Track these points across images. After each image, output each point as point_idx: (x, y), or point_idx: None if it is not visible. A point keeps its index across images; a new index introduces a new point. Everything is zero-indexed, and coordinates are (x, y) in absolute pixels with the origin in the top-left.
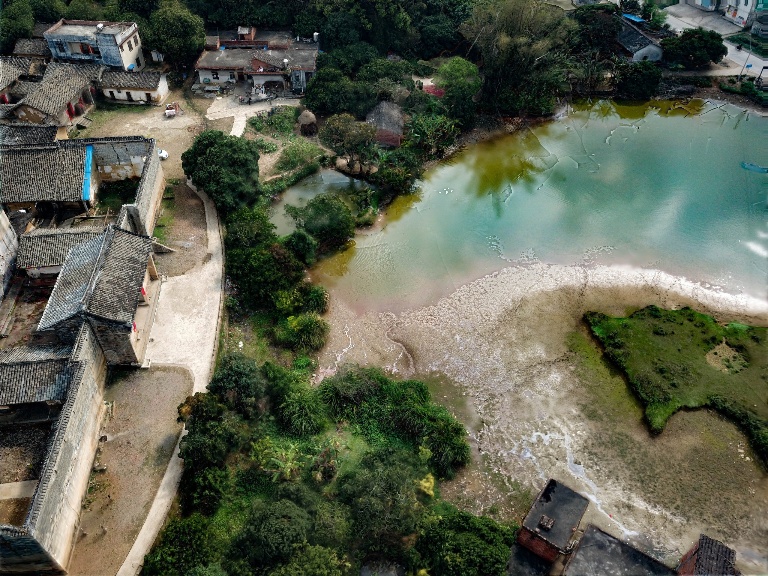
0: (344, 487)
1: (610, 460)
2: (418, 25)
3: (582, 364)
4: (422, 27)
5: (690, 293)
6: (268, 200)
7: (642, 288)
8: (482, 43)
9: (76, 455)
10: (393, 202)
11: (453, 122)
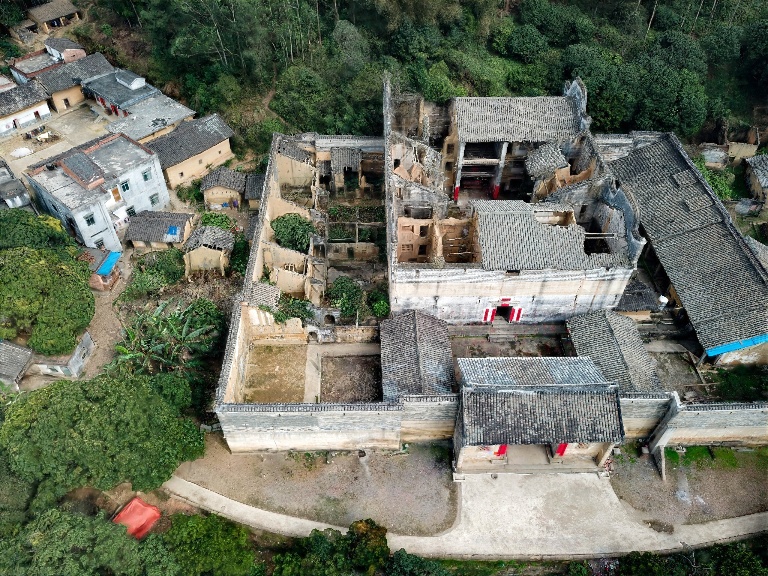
0: None
1: None
2: None
3: None
4: None
5: None
6: None
7: None
8: None
9: (316, 430)
10: None
11: None
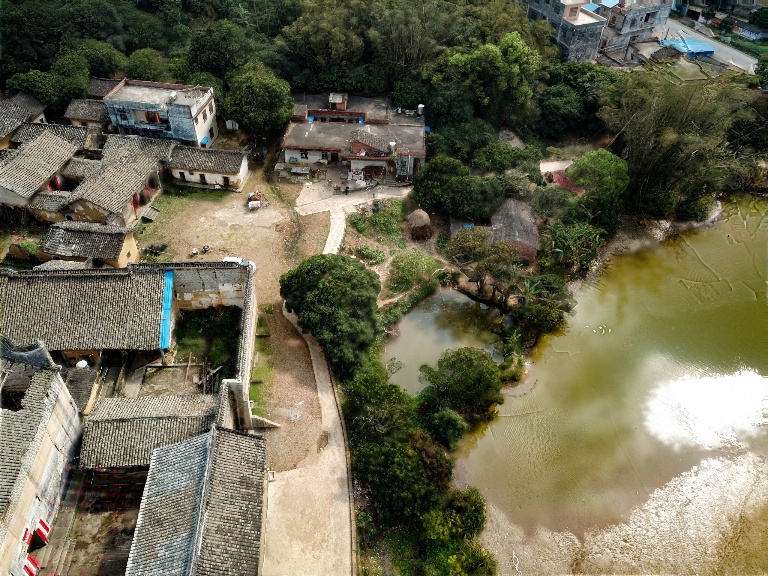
0: None
1: None
2: (536, 96)
3: None
4: (542, 100)
5: None
6: (383, 336)
7: None
8: (633, 134)
9: None
10: (538, 343)
11: (598, 231)
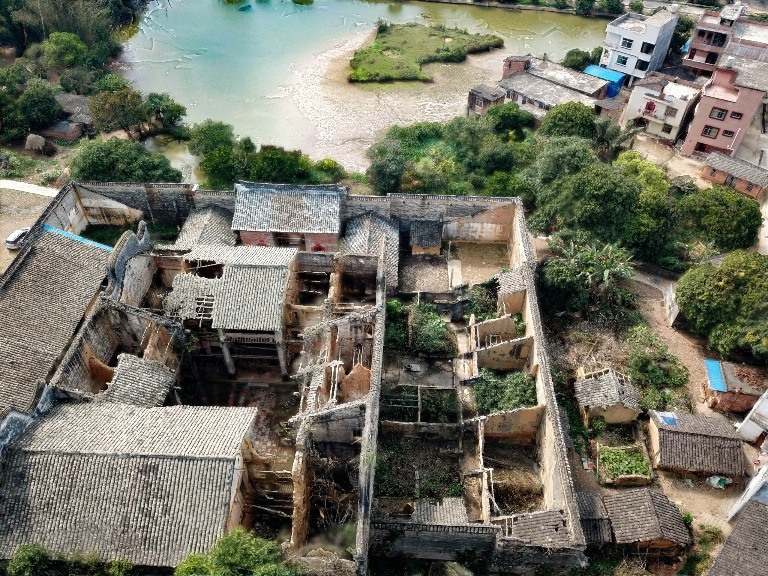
0: (464, 150)
1: (445, 95)
2: None
3: (383, 90)
4: None
5: (342, 52)
6: None
7: (332, 62)
8: (54, 15)
9: None
10: None
11: None
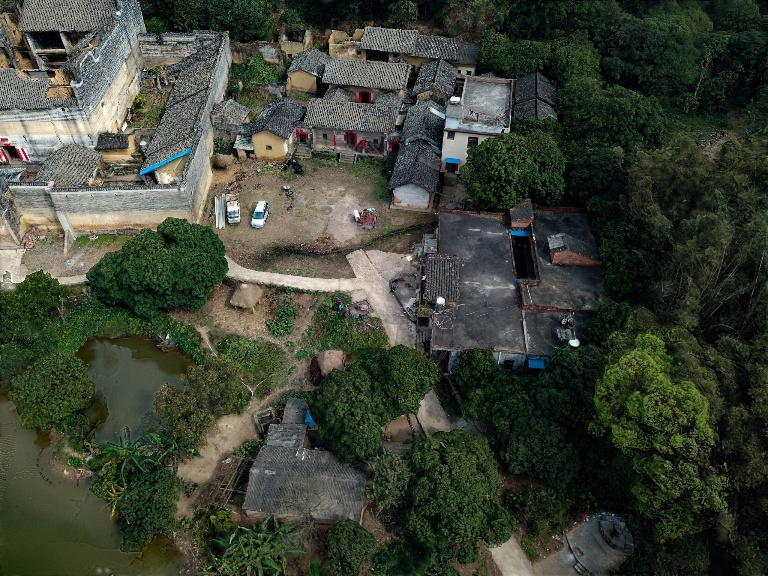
0: None
1: None
2: None
3: None
4: None
5: None
6: None
7: None
8: None
9: None
10: None
11: None
